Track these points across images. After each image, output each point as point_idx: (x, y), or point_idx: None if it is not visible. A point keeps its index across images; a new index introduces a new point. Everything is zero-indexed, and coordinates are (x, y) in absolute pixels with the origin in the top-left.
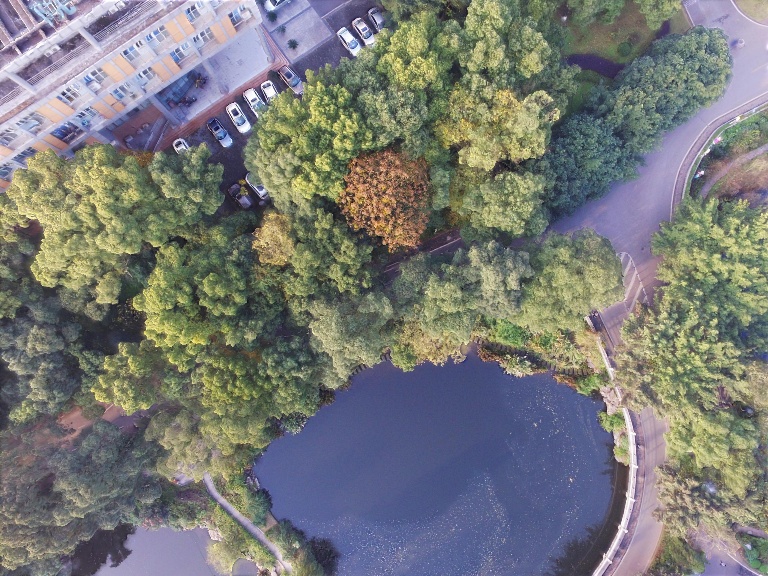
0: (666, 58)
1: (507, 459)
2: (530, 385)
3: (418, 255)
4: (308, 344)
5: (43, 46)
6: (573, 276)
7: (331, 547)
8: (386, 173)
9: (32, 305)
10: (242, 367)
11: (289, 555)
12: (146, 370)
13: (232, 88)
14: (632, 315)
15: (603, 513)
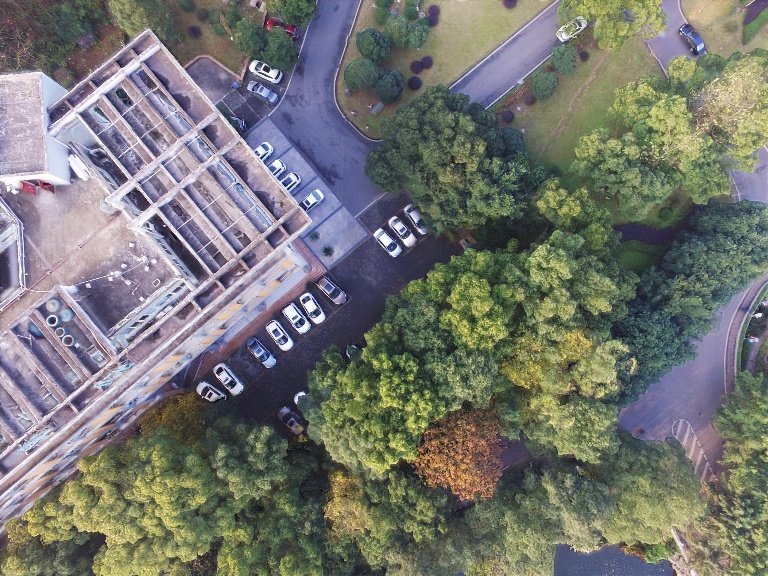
0: (717, 241)
1: None
2: (598, 559)
3: None
4: None
5: (100, 400)
6: (655, 507)
7: None
8: (462, 441)
9: None
10: None
11: None
12: None
13: (269, 304)
14: None
15: None
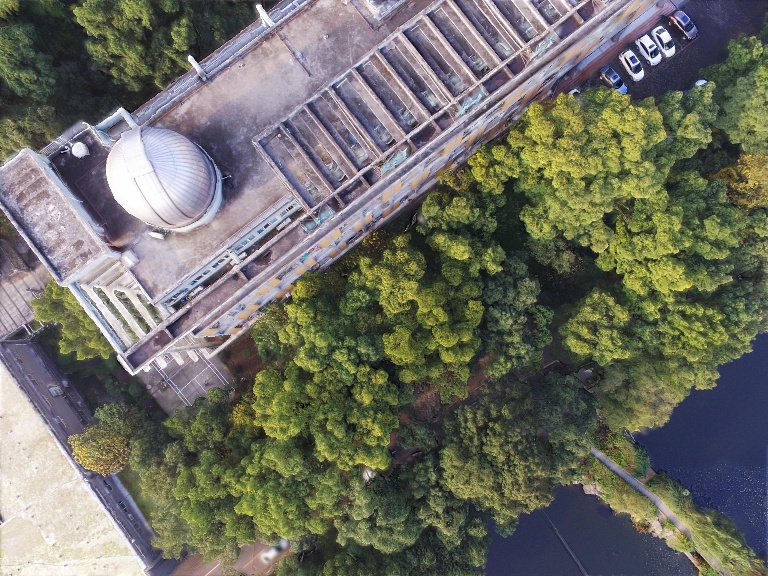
0: None
1: None
2: None
3: None
4: None
5: None
6: None
7: (709, 494)
8: None
9: (511, 259)
10: (717, 311)
11: (681, 503)
12: None
13: (622, 36)
14: None
15: None
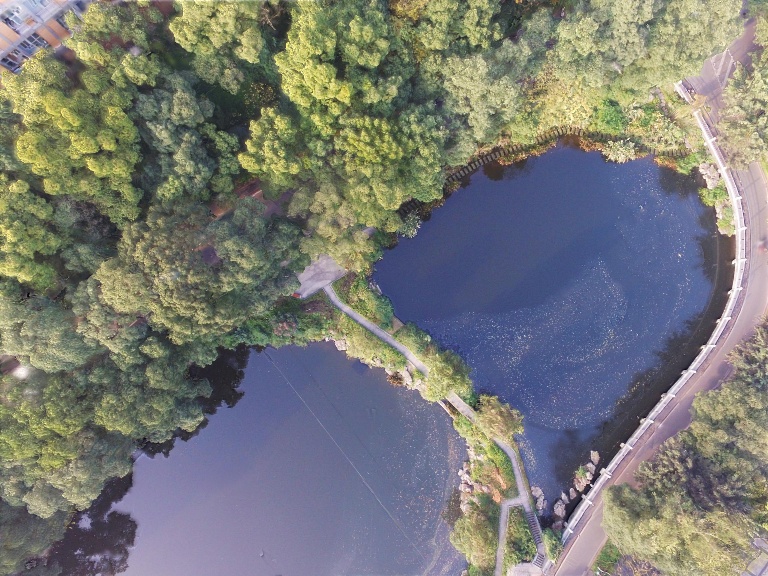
0: None
1: (618, 242)
2: (633, 170)
3: (541, 10)
4: (439, 111)
5: None
6: (700, 4)
7: (458, 342)
8: None
9: (169, 75)
10: (387, 123)
11: (422, 348)
12: (293, 132)
13: None
14: (737, 71)
15: (699, 304)
